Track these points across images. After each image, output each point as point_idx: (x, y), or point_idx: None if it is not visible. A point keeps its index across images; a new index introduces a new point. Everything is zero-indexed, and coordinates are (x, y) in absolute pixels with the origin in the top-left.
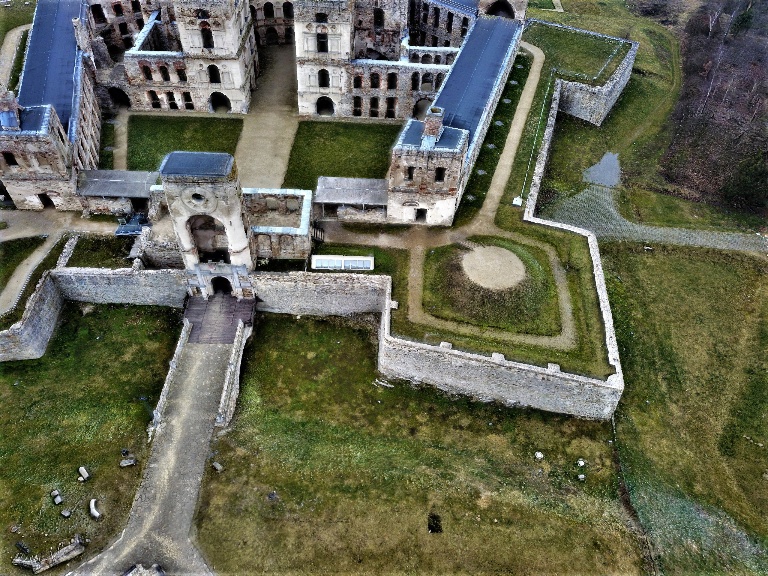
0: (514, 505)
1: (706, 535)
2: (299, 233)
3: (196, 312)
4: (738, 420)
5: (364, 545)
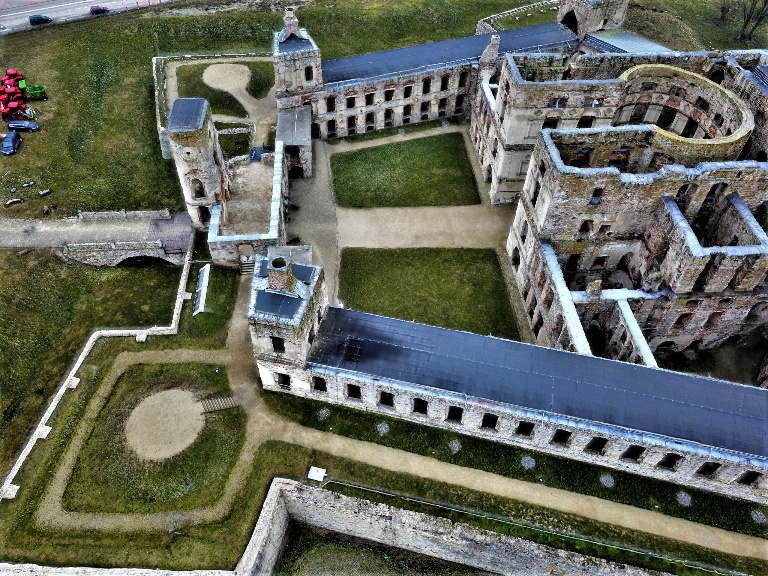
0: None
1: None
2: (209, 236)
3: (185, 218)
4: None
5: None
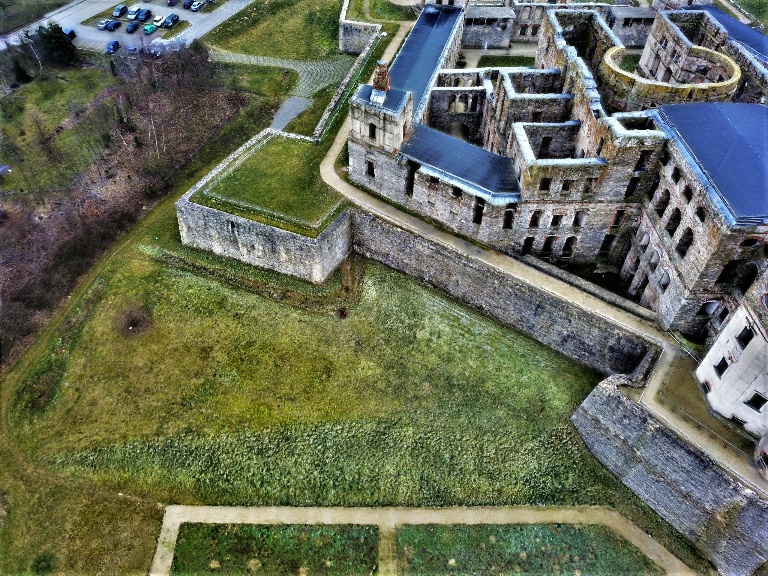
0: None
1: None
2: None
3: None
4: None
5: None
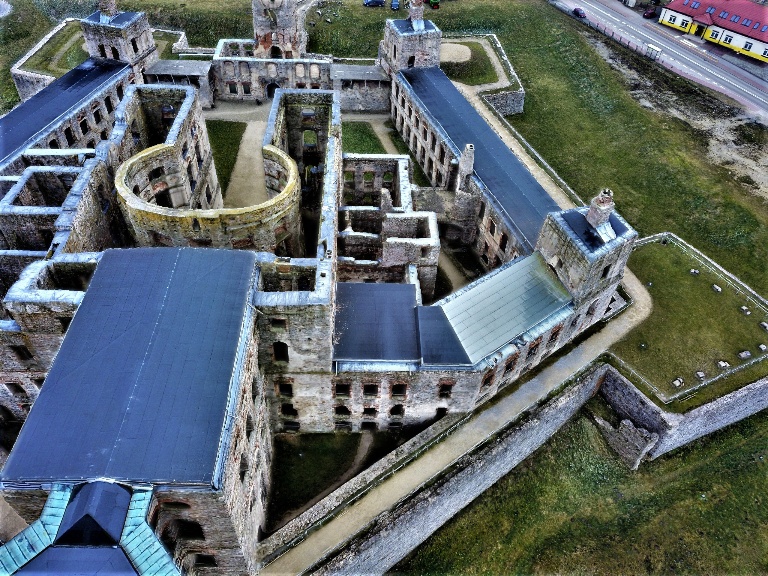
0: (147, 8)
1: (70, 8)
2: None
3: None
4: (8, 39)
5: (213, 3)
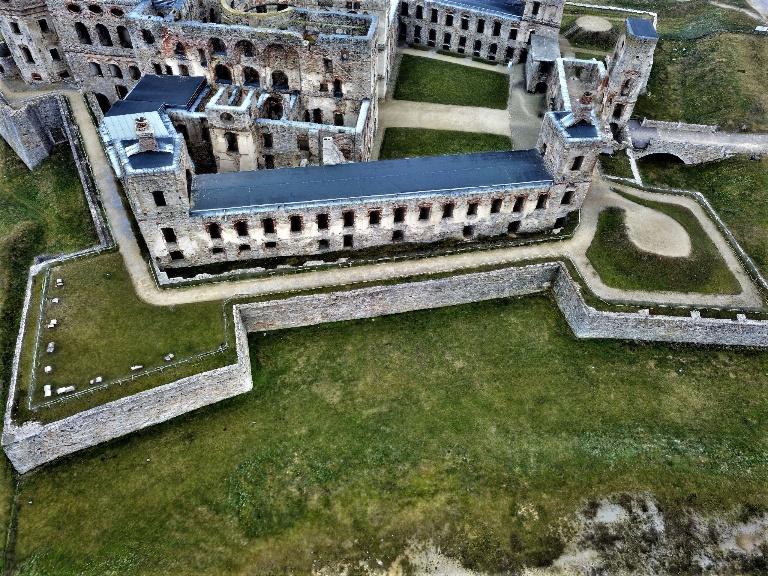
0: None
1: None
2: None
3: None
4: None
5: (761, 88)
